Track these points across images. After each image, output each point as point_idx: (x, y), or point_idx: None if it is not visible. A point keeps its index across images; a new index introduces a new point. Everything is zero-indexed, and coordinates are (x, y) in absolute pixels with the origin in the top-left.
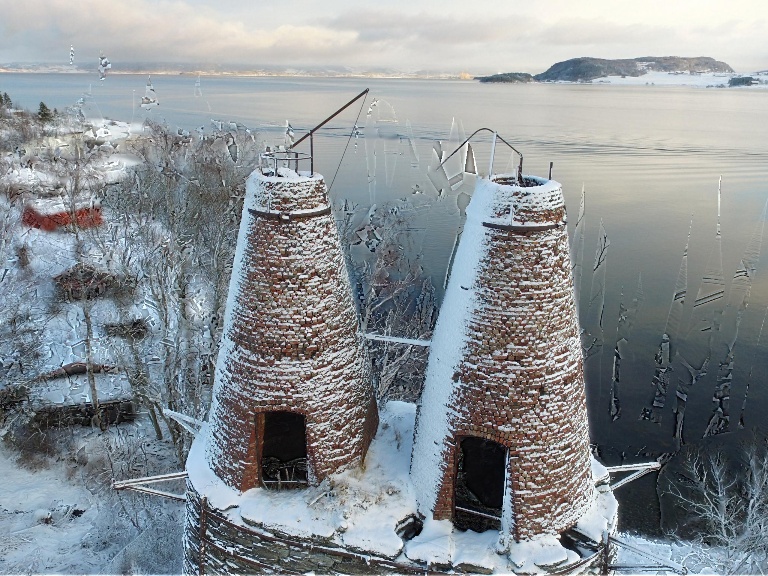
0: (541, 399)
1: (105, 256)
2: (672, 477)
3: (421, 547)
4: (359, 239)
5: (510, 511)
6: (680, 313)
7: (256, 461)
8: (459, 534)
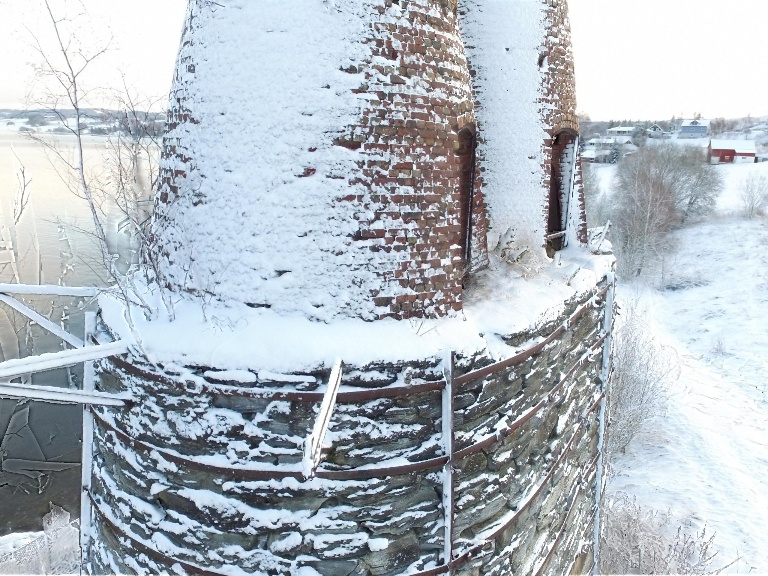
0: None
1: None
2: None
3: None
4: None
5: (579, 211)
6: (126, 245)
7: None
8: None
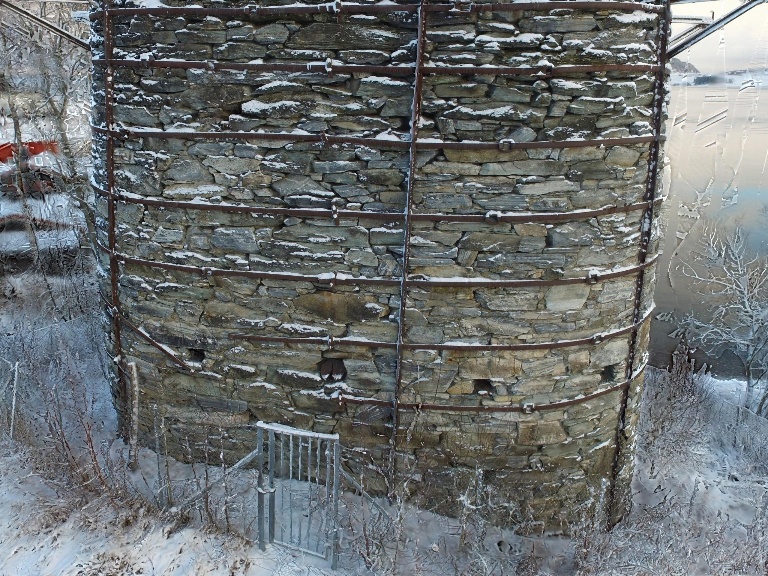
0: None
1: (33, 38)
2: (686, 259)
3: None
4: None
5: None
6: (680, 141)
7: None
8: None
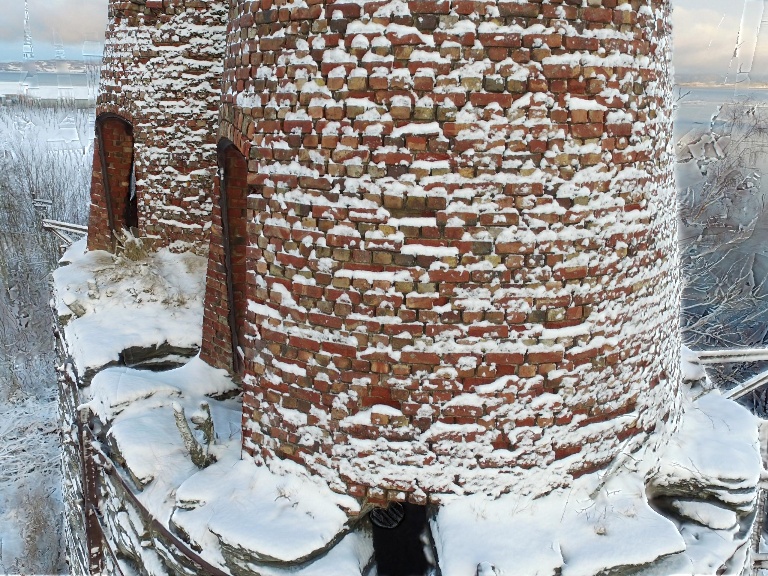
0: (333, 1)
1: None
2: None
3: (102, 374)
4: (689, 155)
5: None
6: None
7: (106, 206)
8: (215, 404)
